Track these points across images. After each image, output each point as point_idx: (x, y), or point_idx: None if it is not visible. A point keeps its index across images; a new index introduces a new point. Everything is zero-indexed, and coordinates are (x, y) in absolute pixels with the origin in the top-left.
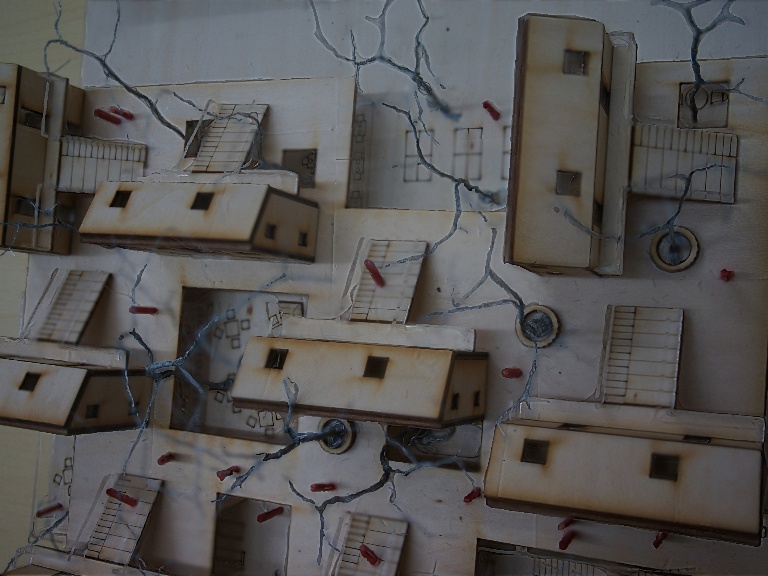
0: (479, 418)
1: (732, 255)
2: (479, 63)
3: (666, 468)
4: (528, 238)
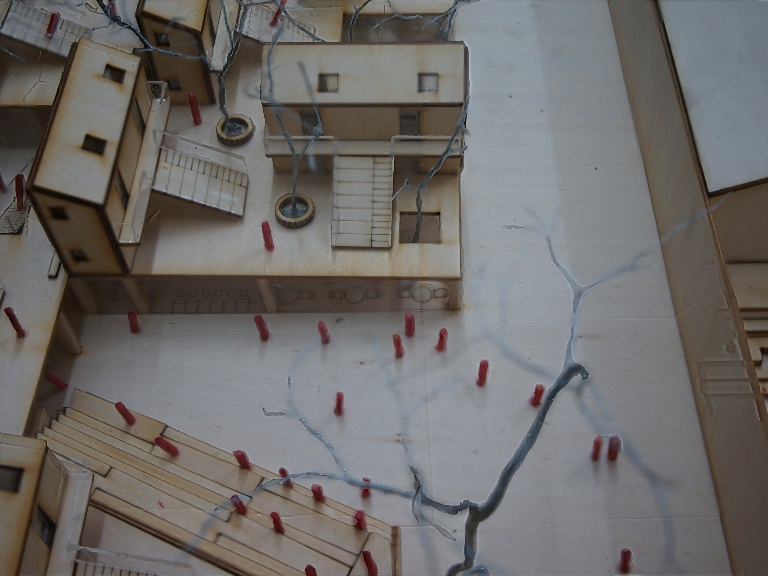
0: (160, 94)
1: (288, 249)
2: (480, 118)
3: (94, 145)
4: (282, 54)
